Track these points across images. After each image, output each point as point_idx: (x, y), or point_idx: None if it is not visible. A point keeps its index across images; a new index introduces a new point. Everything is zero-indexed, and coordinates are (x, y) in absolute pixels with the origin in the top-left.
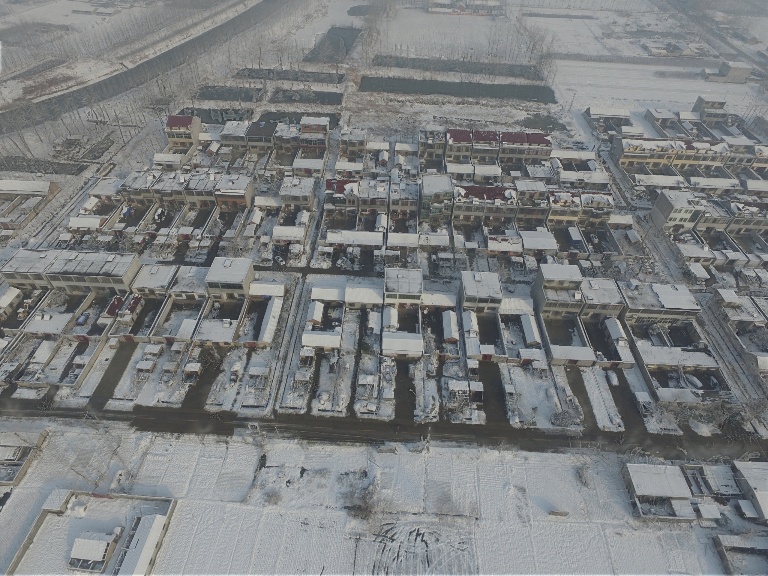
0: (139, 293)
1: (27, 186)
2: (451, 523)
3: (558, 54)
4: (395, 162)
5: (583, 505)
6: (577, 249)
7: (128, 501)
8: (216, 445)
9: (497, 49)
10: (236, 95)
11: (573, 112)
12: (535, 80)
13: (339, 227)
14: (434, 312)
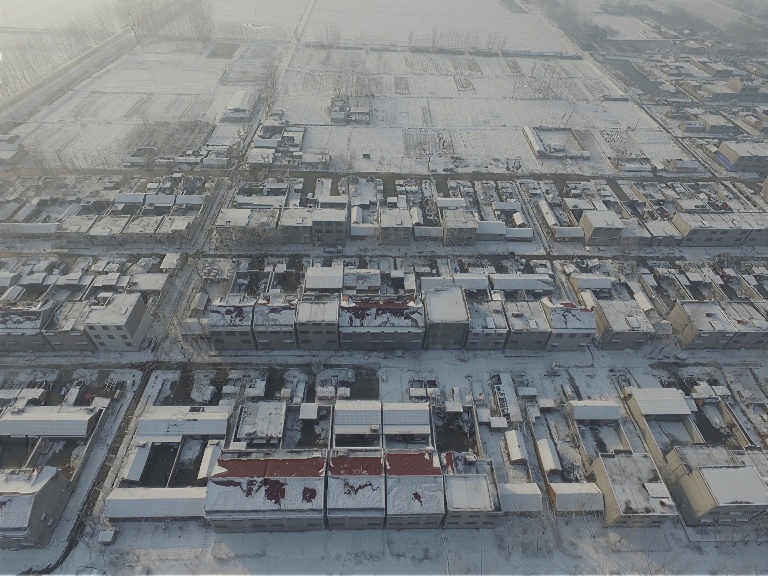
0: None
1: None
2: (415, 156)
3: None
4: None
5: None
6: None
7: None
8: None
9: None
10: None
11: None
12: None
13: None
14: None
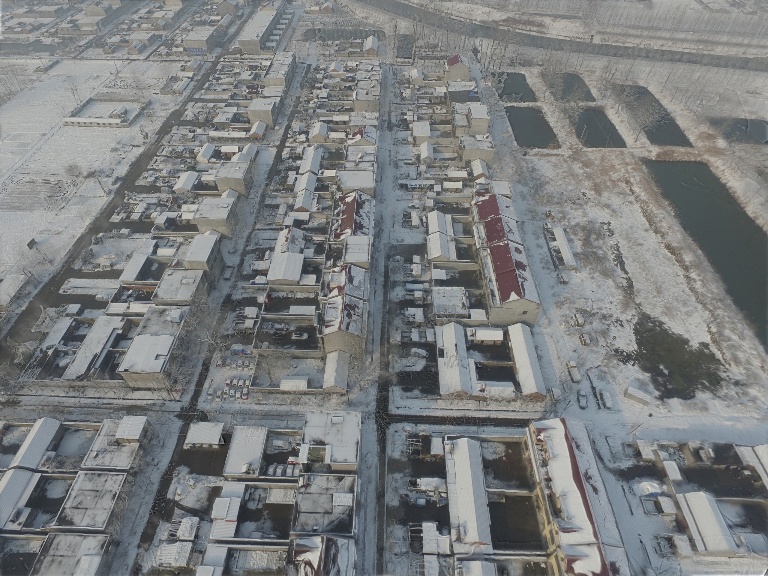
0: None
1: None
2: (61, 205)
3: None
4: None
5: (30, 259)
6: None
7: None
8: None
9: None
10: None
11: None
12: None
13: (335, 157)
14: None
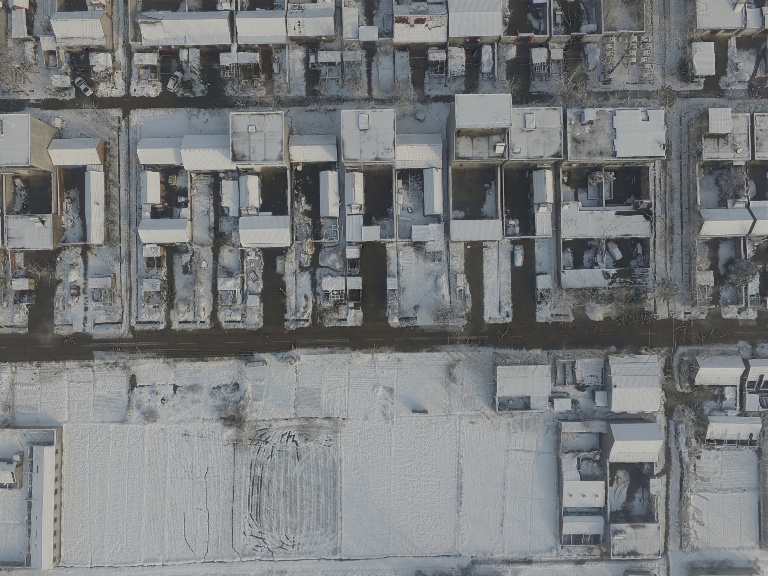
0: None
1: None
2: (320, 425)
3: None
4: None
5: (446, 400)
6: (537, 19)
7: (16, 430)
8: (81, 369)
9: None
10: None
11: None
12: None
13: None
14: (311, 167)
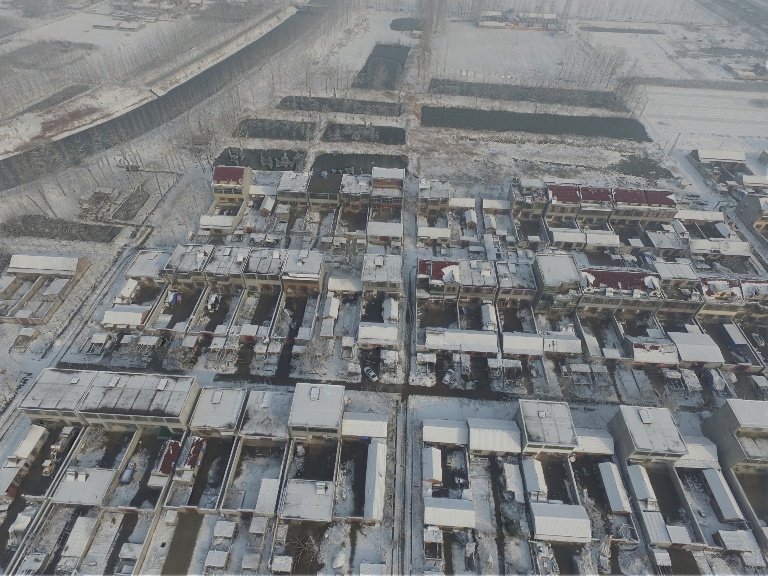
0: (198, 429)
1: (50, 263)
2: None
3: (637, 78)
4: (486, 225)
5: None
6: (741, 356)
7: None
8: None
9: (570, 73)
10: (285, 133)
11: (674, 153)
12: (620, 112)
13: (435, 320)
14: (583, 459)
